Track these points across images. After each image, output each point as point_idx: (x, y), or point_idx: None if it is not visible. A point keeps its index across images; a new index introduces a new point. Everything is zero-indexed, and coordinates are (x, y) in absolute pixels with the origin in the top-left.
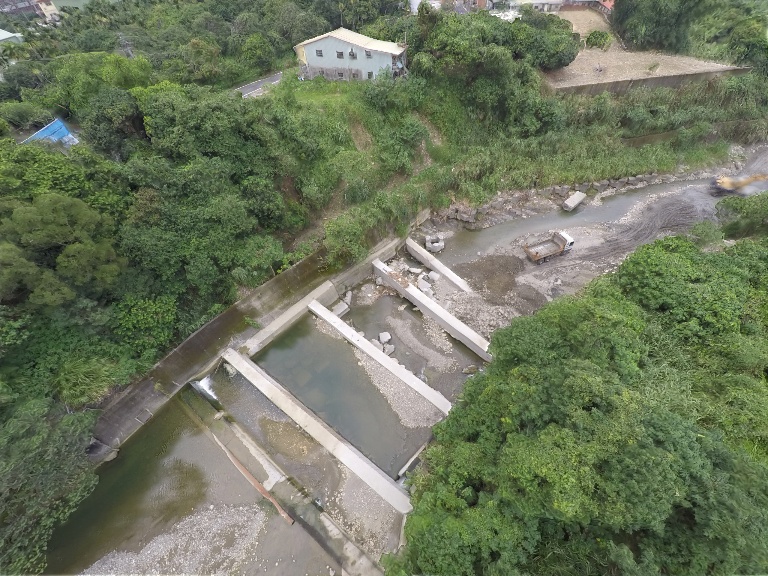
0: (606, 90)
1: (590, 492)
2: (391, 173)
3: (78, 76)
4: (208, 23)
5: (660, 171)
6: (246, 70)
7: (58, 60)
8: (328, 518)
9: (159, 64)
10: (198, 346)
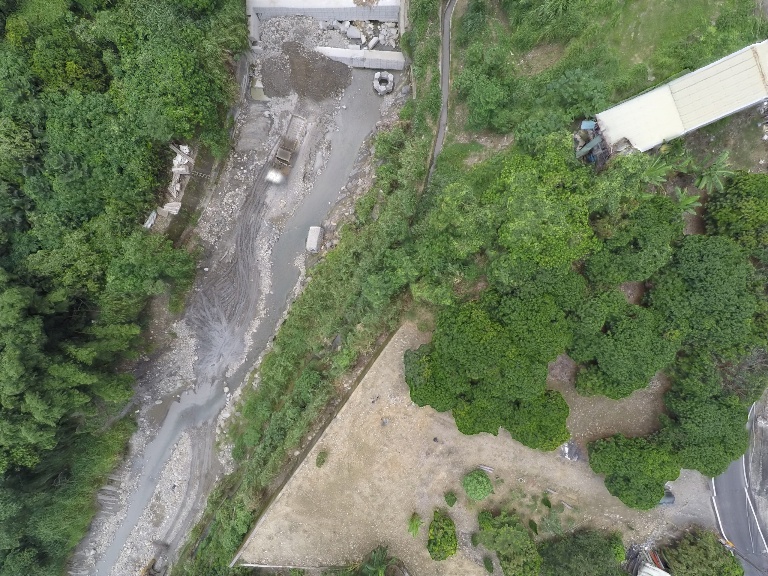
0: None
1: None
2: (467, 65)
3: None
4: None
5: None
6: None
7: None
8: None
9: None
10: None
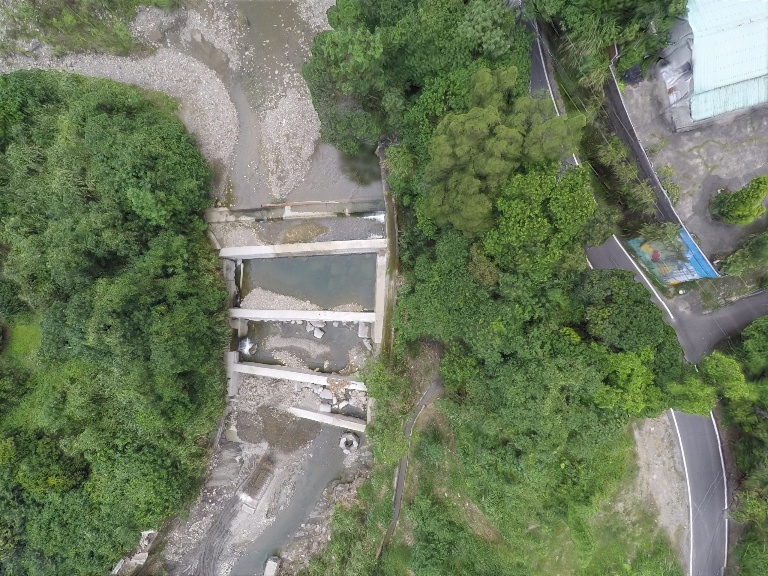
0: None
1: None
2: None
3: None
4: None
5: None
6: None
7: None
8: (251, 220)
9: None
10: None
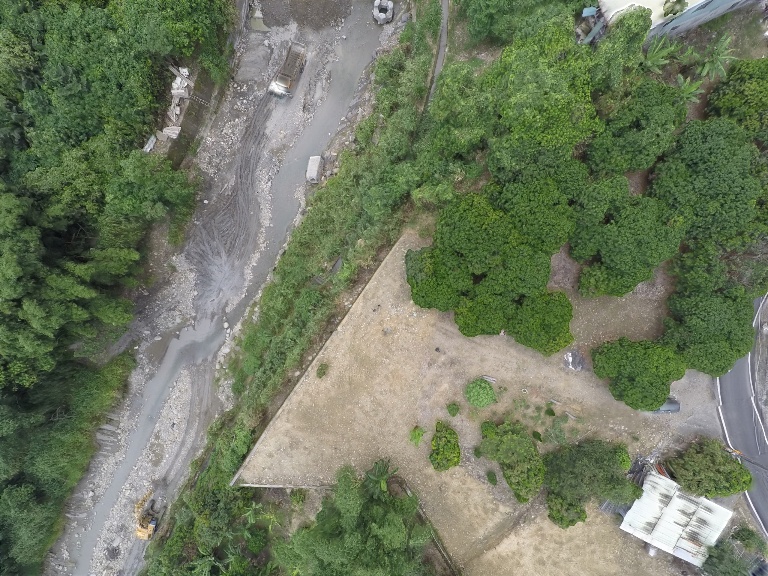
0: None
1: None
2: None
3: None
4: None
5: None
6: None
7: None
8: None
9: None
10: None
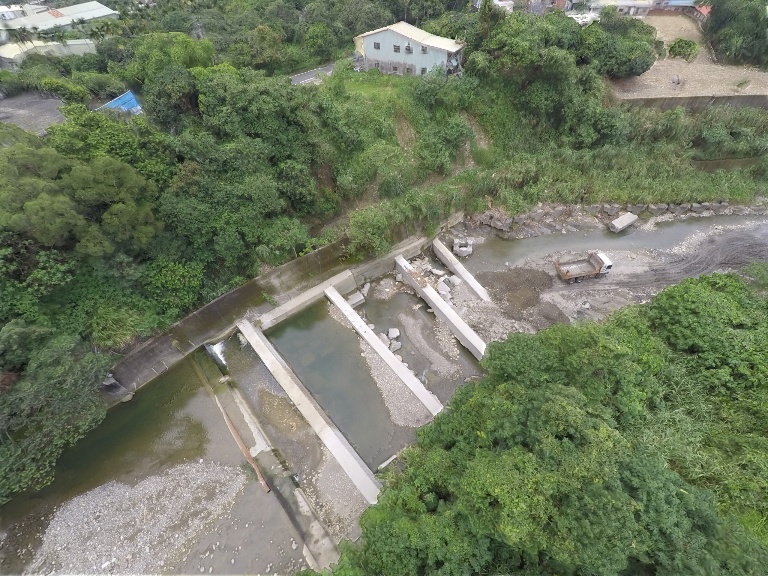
0: (680, 105)
1: (542, 523)
2: (429, 171)
3: (153, 53)
4: (280, 10)
5: (732, 201)
6: (307, 58)
7: (141, 38)
8: (302, 494)
9: (227, 47)
10: (216, 313)
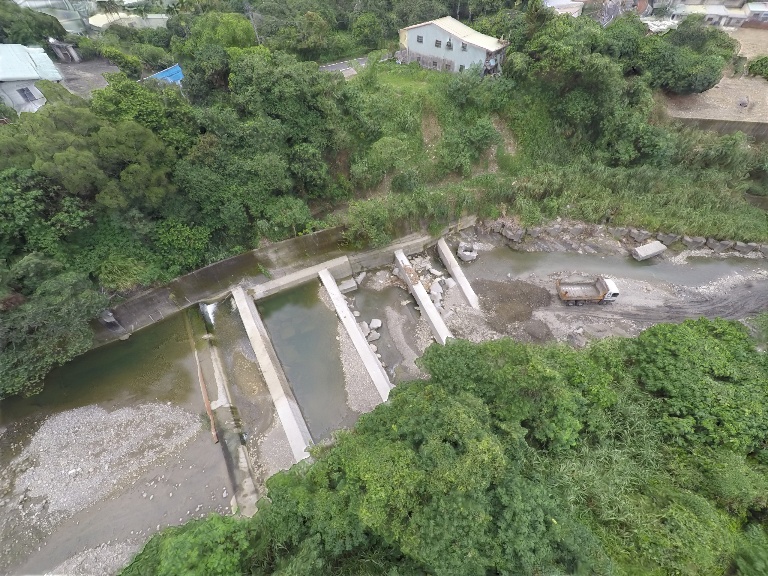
0: None
1: (402, 516)
2: (447, 171)
3: (205, 31)
4: None
5: None
6: (355, 46)
7: (203, 16)
8: (245, 451)
9: (276, 30)
10: (213, 276)
